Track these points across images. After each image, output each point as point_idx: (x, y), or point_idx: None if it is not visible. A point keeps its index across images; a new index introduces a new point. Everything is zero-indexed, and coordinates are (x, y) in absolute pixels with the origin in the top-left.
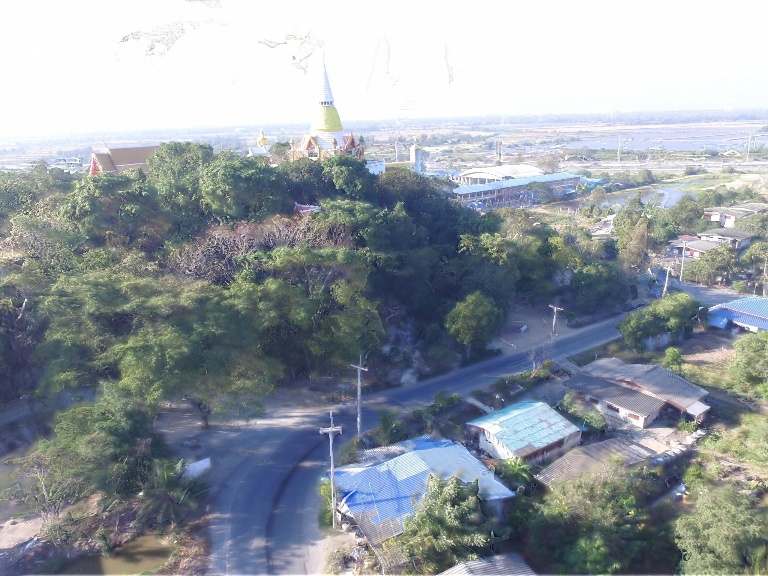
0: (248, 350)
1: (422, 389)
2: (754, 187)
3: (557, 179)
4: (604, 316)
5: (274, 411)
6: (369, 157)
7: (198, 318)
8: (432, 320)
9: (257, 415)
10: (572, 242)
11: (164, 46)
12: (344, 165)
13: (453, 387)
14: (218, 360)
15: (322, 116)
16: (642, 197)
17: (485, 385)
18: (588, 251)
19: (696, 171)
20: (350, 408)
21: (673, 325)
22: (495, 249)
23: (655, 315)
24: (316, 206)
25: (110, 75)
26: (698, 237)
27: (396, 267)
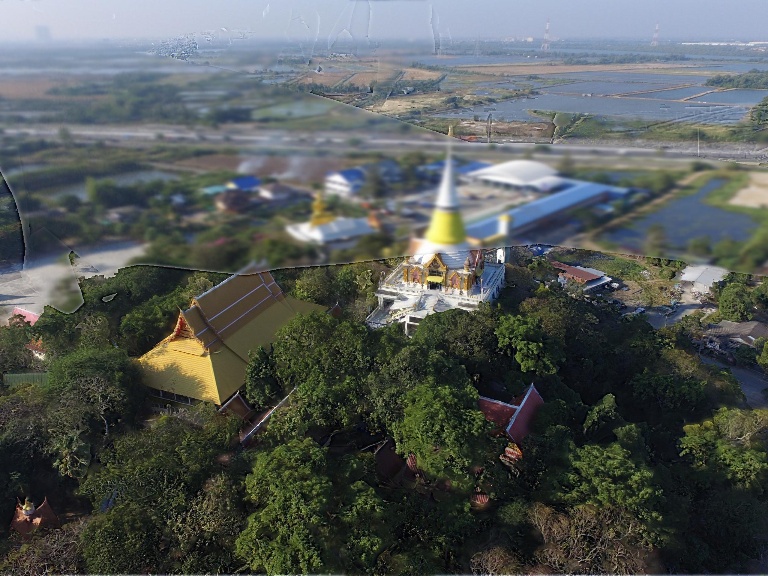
0: None
1: None
2: None
3: None
4: None
5: None
6: None
7: None
8: None
9: None
10: (691, 338)
11: None
12: (527, 336)
13: None
14: None
15: None
16: None
17: None
18: None
19: None
20: None
21: None
22: (742, 468)
23: None
24: (507, 404)
25: None
26: None
27: None
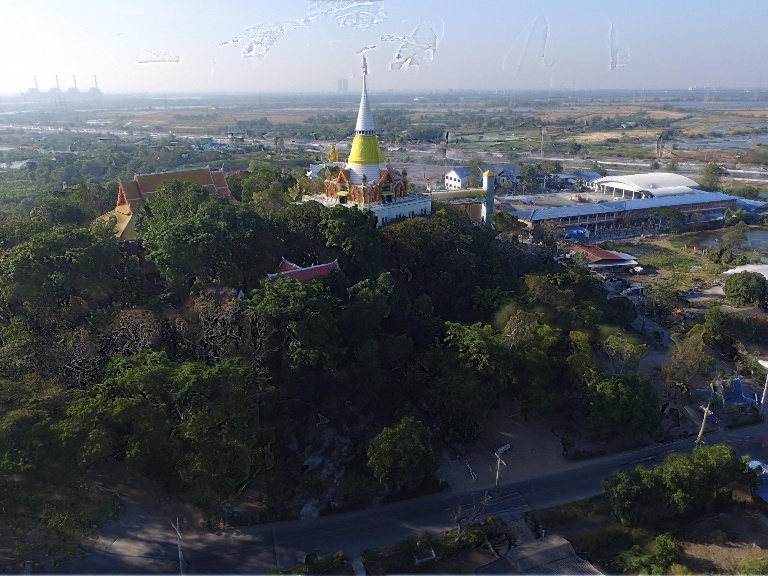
0: (64, 486)
1: (316, 530)
2: None
3: (702, 201)
4: (623, 445)
5: (144, 527)
6: (520, 144)
7: (17, 443)
8: (394, 420)
9: (124, 530)
10: (656, 309)
11: (263, 47)
12: (341, 218)
13: (352, 536)
14: (16, 500)
15: (358, 147)
16: None
17: (390, 541)
18: (619, 355)
19: None
20: (219, 543)
21: (680, 500)
22: (475, 349)
23: (660, 479)
24: (297, 266)
25: (207, 78)
26: None
27: (333, 366)
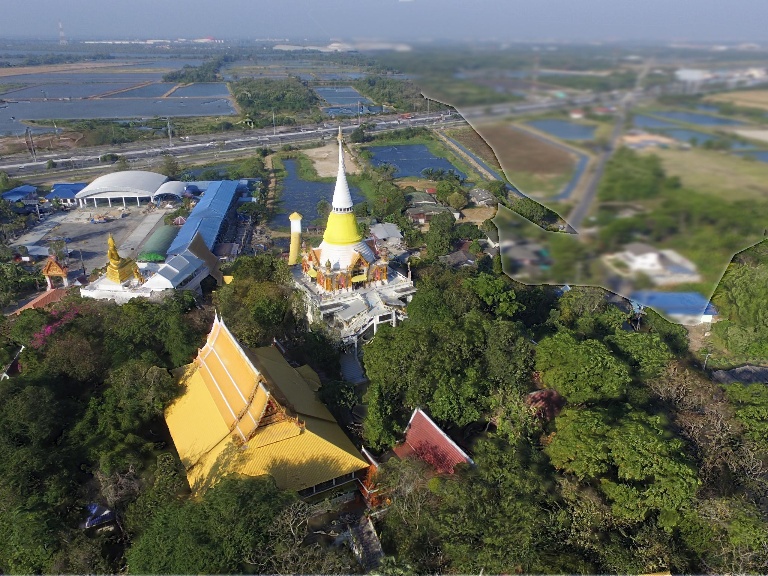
0: None
1: None
2: (369, 172)
3: None
4: None
5: None
6: None
7: None
8: None
9: None
10: None
11: None
12: None
13: None
14: None
15: (353, 225)
16: (368, 206)
17: None
18: None
19: (264, 151)
20: None
21: None
22: None
23: None
24: None
25: None
26: (469, 240)
27: None
